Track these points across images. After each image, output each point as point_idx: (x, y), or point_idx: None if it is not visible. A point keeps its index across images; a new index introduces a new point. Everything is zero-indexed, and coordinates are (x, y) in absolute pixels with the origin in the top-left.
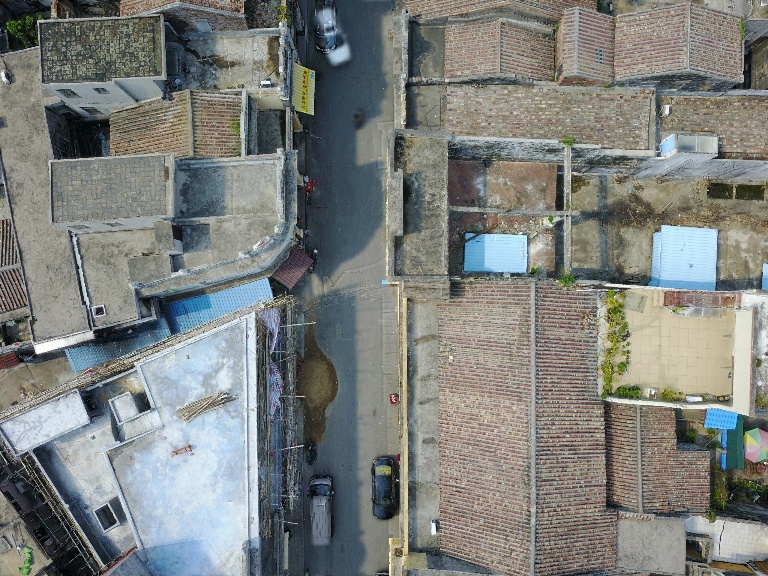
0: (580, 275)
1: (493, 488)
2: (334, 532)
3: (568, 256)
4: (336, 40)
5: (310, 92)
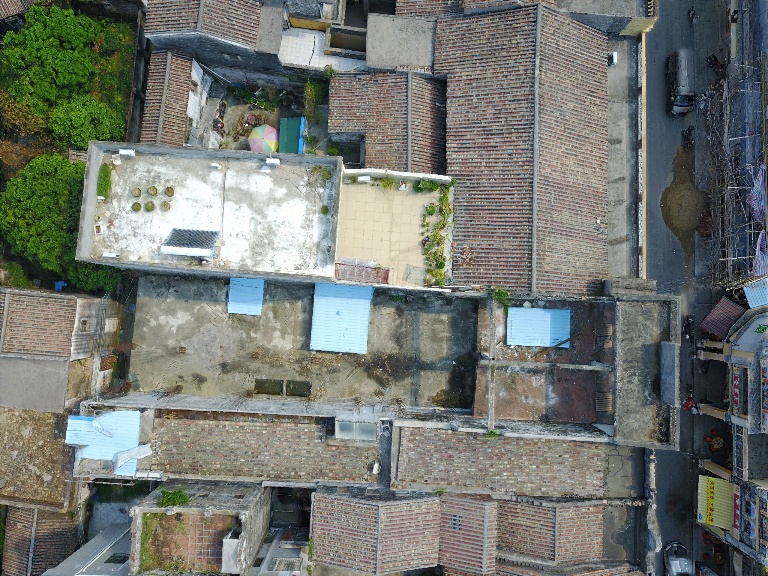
0: (440, 307)
1: (567, 94)
2: (665, 62)
3: (494, 319)
4: (664, 556)
5: (703, 499)
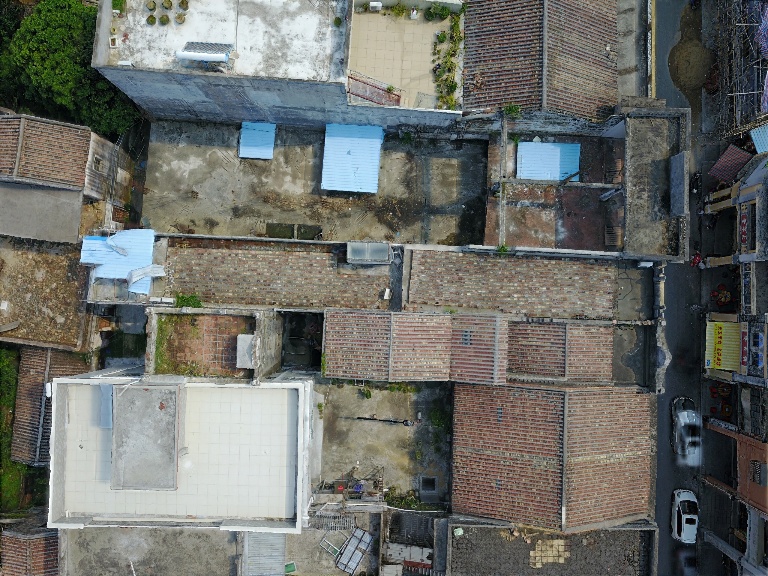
0: (450, 151)
1: None
2: None
3: (505, 137)
4: (671, 409)
5: (711, 345)
